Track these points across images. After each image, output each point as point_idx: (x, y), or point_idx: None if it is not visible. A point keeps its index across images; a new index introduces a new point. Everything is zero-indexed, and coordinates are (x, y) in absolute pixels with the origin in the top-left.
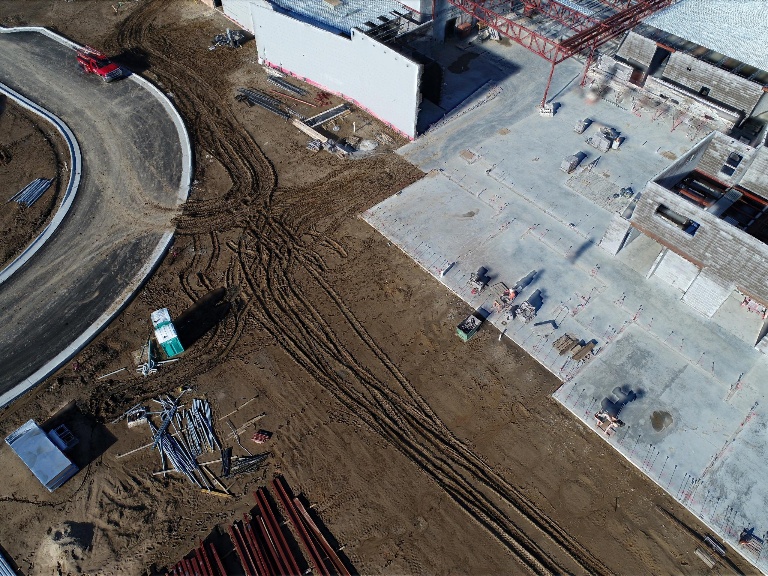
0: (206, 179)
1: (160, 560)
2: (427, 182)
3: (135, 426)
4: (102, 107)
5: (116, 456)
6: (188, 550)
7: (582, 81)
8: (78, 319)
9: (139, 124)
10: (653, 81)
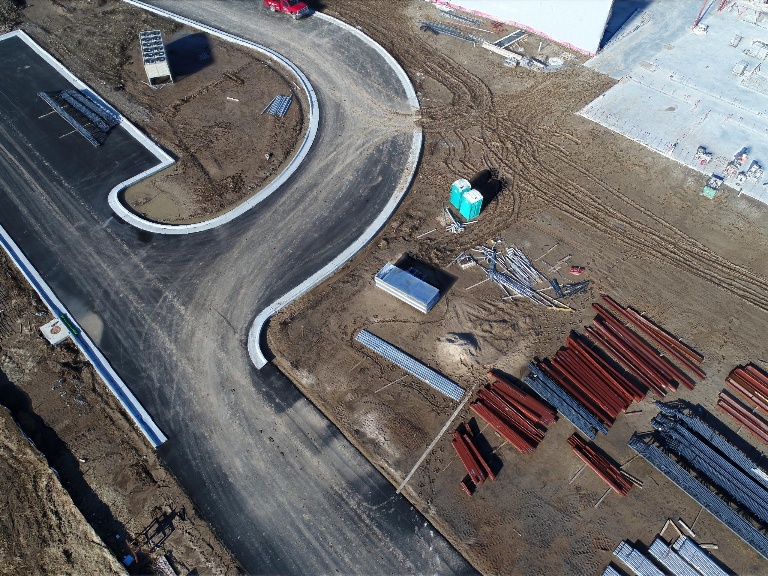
0: (427, 91)
1: (539, 354)
2: (623, 86)
3: (468, 268)
4: (303, 39)
5: (464, 288)
6: (558, 346)
7: (720, 6)
8: (375, 197)
9: (344, 51)
10: None
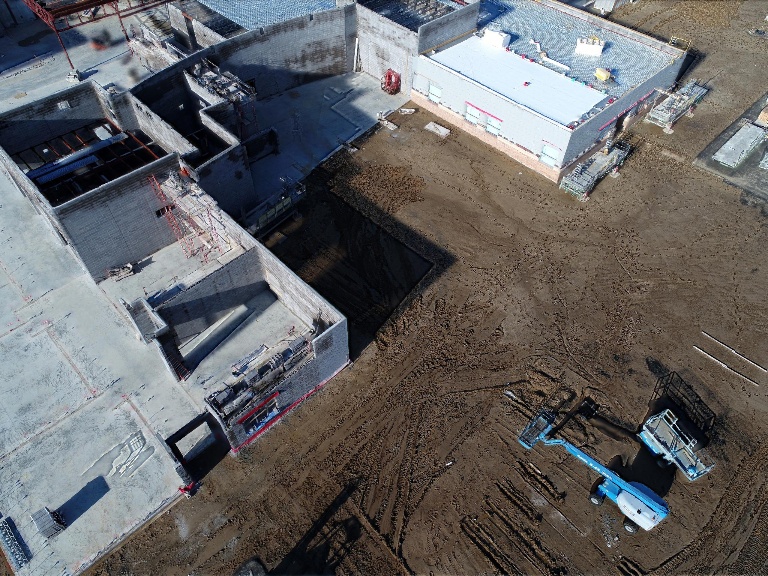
0: None
1: None
2: None
3: None
4: None
5: None
6: None
7: (131, 50)
8: None
9: None
10: (169, 47)
